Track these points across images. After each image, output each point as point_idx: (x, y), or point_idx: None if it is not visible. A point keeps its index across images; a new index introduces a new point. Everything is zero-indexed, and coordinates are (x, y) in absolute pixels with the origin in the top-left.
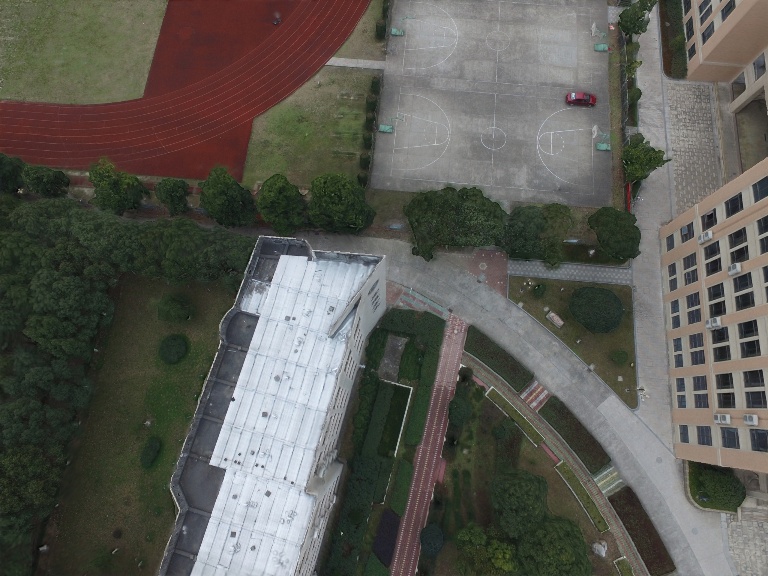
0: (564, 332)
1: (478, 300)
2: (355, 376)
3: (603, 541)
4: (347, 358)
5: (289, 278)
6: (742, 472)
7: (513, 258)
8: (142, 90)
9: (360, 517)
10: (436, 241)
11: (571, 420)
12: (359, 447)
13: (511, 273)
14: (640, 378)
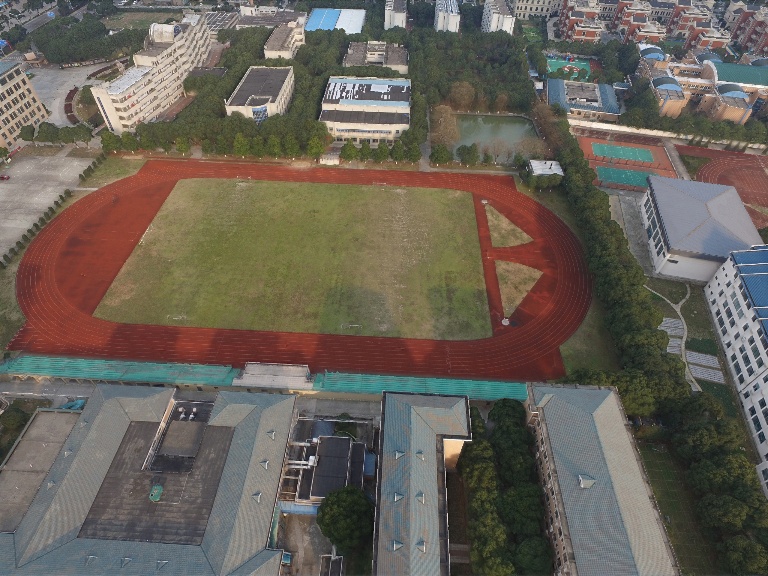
0: None
1: None
2: None
3: (79, 107)
4: None
5: None
6: None
7: (64, 145)
8: None
9: None
10: None
11: None
12: None
13: None
14: None
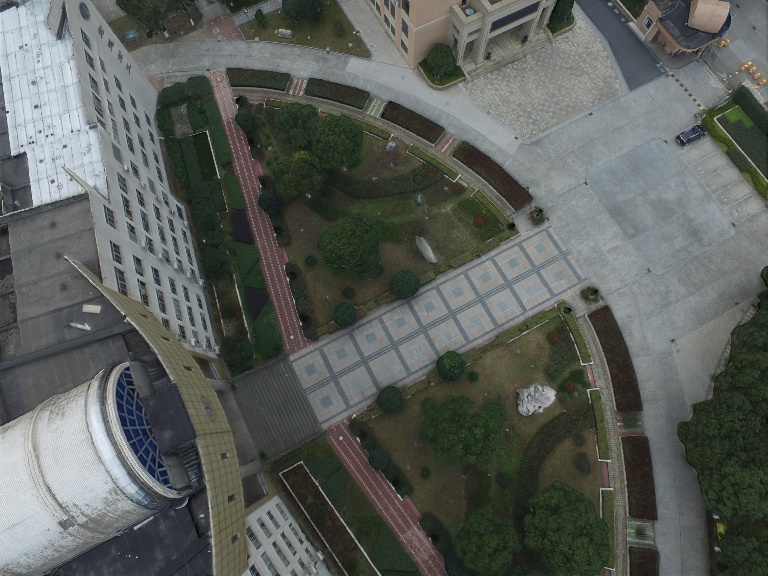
0: (297, 39)
1: (225, 53)
2: (160, 148)
3: None
4: (85, 54)
5: (8, 25)
6: (450, 46)
7: (235, 14)
8: None
9: (211, 222)
10: (150, 6)
11: (329, 84)
12: (188, 187)
13: (239, 23)
14: (364, 38)
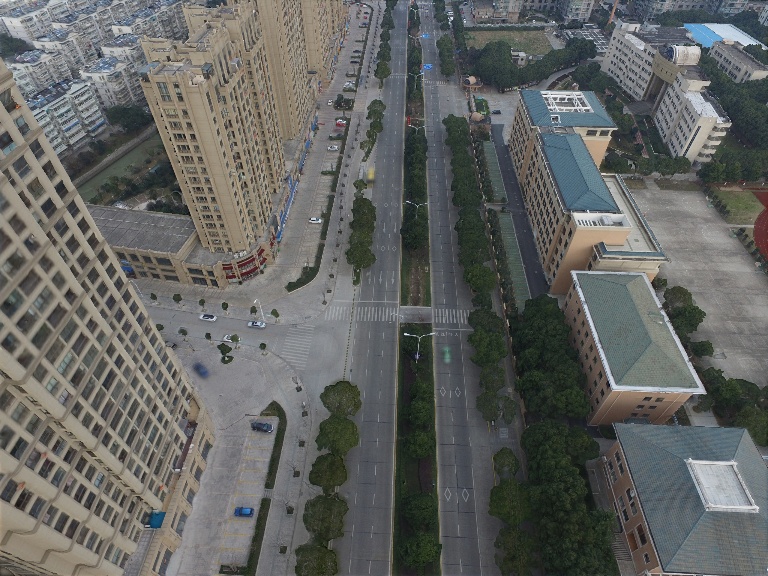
0: None
1: None
2: None
3: None
4: None
5: None
6: None
7: None
8: None
9: None
10: None
11: None
12: None
13: None
14: None
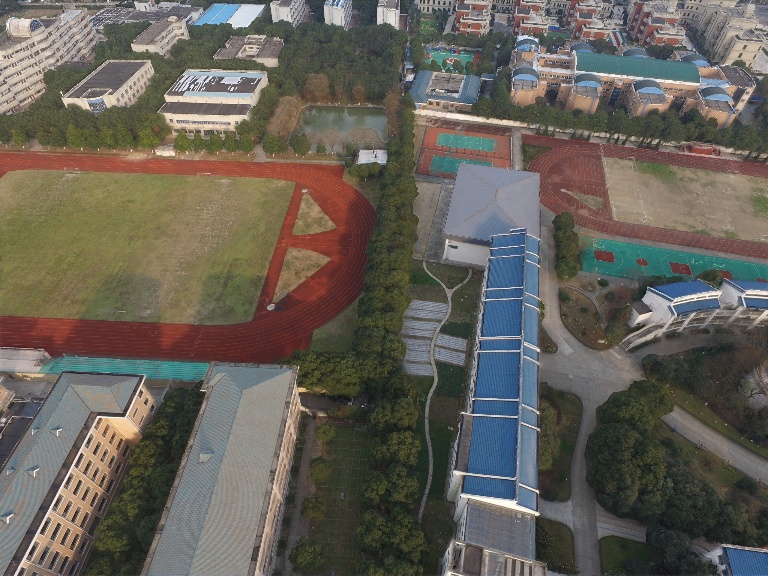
0: None
1: None
2: None
3: None
4: None
5: None
6: None
7: None
8: (7, 173)
9: None
10: None
11: None
12: None
13: None
14: None
